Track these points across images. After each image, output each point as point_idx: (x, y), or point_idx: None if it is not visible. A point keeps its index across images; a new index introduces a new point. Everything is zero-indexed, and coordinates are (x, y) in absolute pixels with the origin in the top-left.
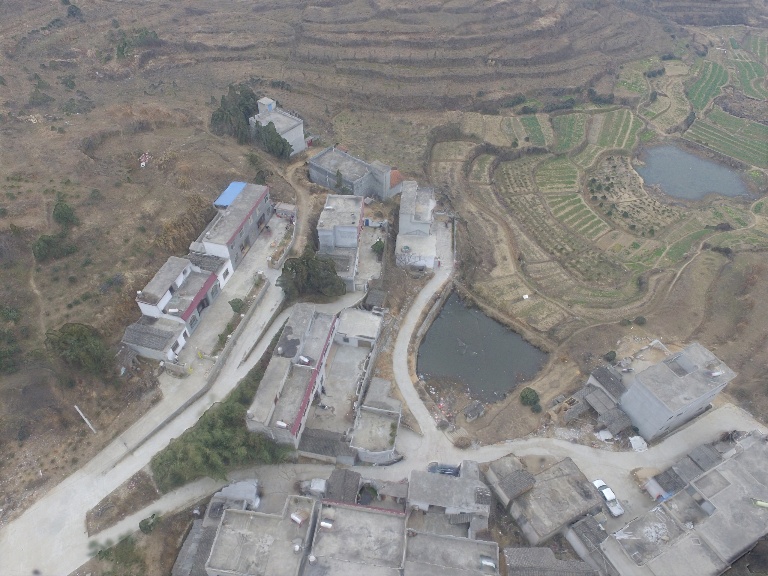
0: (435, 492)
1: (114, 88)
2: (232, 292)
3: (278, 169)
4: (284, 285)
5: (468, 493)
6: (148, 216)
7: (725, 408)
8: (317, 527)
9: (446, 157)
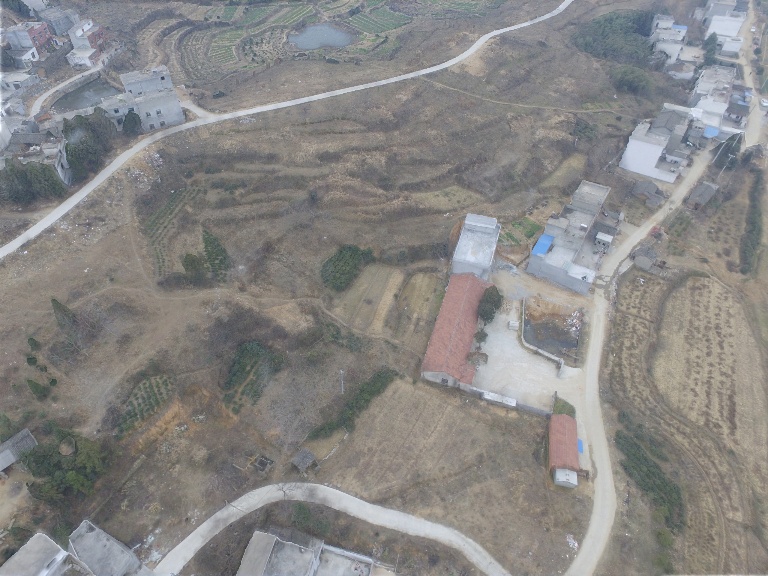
0: (5, 122)
1: None
2: None
3: (15, 18)
4: None
5: (20, 122)
6: None
7: (184, 101)
8: None
9: (156, 26)
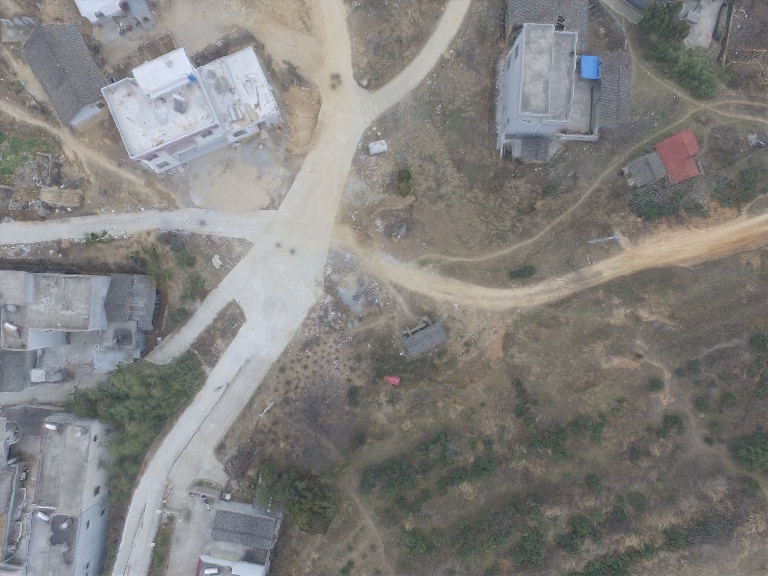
0: None
1: None
2: None
3: None
4: None
5: None
6: None
7: None
8: None
9: None
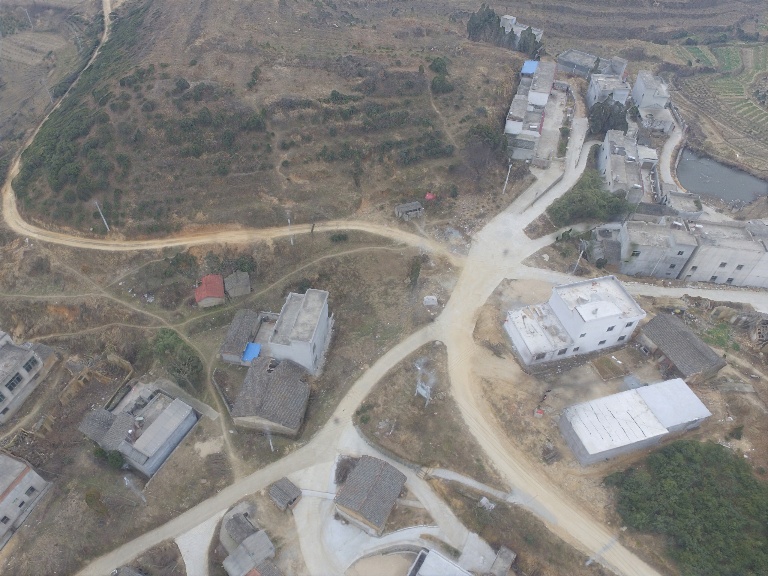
0: None
1: (363, 12)
2: (549, 128)
3: None
4: (594, 120)
5: (765, 231)
6: (484, 75)
7: None
8: (690, 229)
9: (636, 71)
